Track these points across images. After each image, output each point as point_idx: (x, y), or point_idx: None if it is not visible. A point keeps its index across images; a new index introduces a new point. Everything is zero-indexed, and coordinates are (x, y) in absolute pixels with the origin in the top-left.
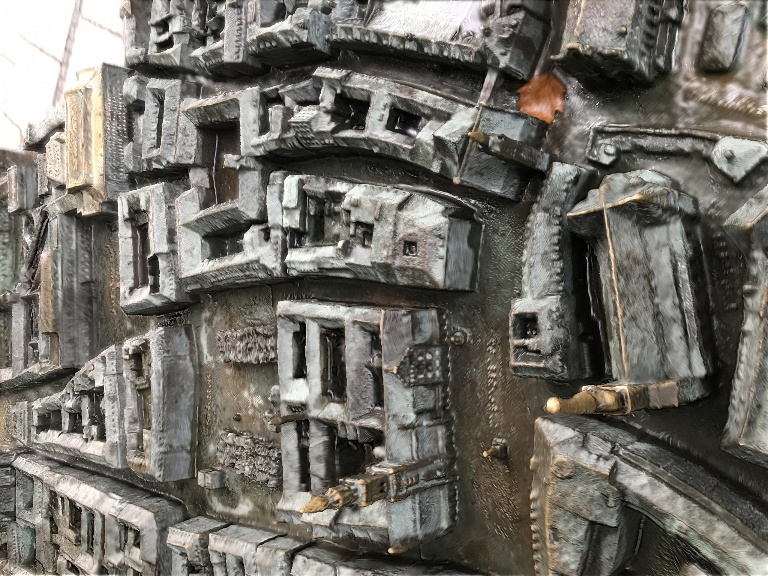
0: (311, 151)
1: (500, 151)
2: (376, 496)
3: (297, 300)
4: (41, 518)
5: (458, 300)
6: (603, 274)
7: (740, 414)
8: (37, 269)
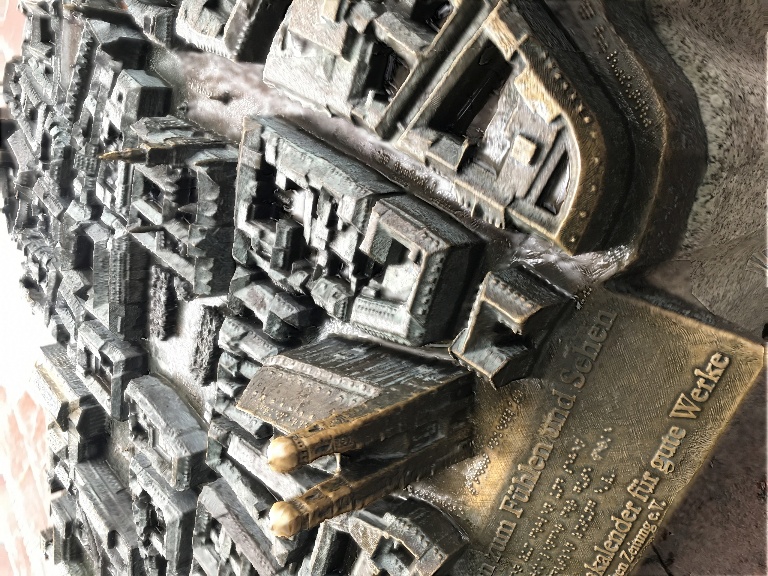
0: None
1: (89, 6)
2: None
3: None
4: None
5: (175, 103)
6: None
7: None
8: None
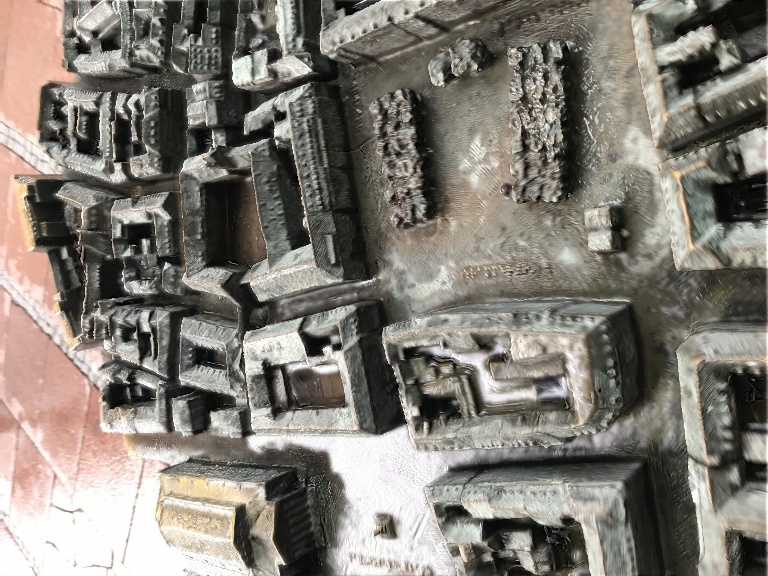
0: (233, 83)
1: None
2: None
3: None
4: None
5: None
6: None
7: None
8: None
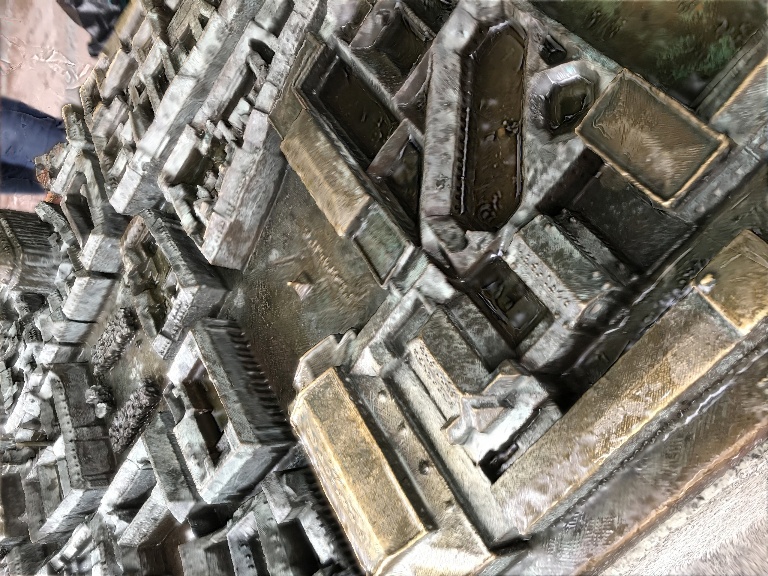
0: None
1: None
2: None
3: (101, 490)
4: None
5: None
6: None
7: None
8: (431, 115)
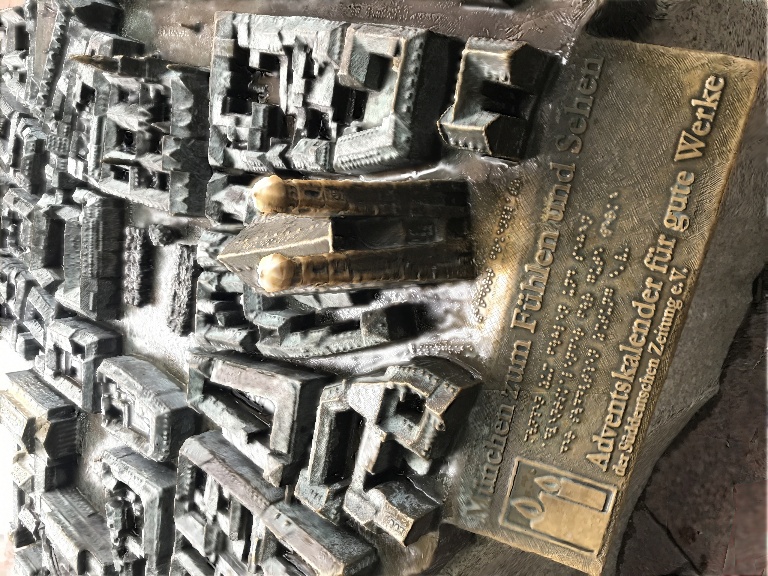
0: None
1: None
2: None
3: None
4: None
5: None
6: None
7: None
8: None
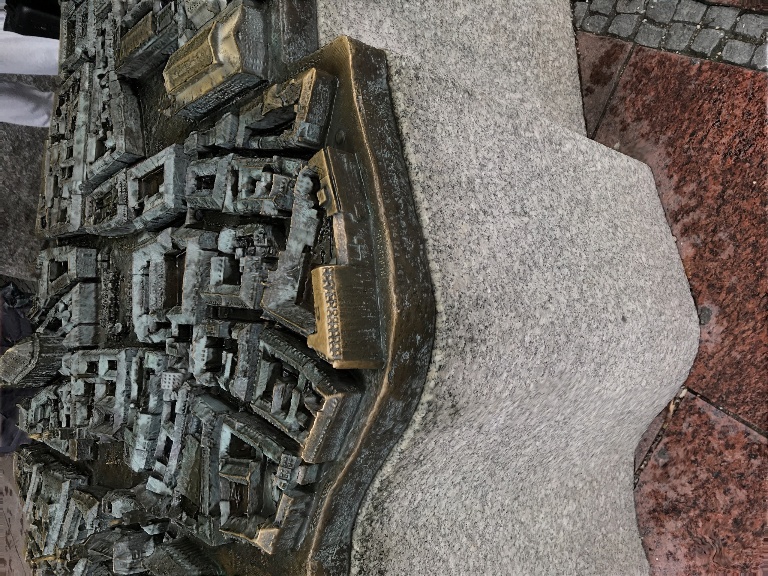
0: None
1: None
2: (65, 439)
3: None
4: (79, 54)
5: None
6: (109, 548)
7: (97, 574)
8: None
